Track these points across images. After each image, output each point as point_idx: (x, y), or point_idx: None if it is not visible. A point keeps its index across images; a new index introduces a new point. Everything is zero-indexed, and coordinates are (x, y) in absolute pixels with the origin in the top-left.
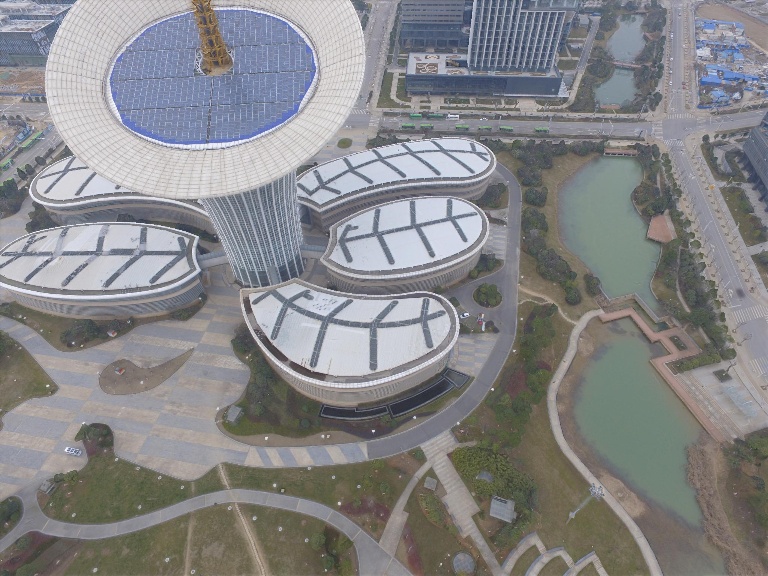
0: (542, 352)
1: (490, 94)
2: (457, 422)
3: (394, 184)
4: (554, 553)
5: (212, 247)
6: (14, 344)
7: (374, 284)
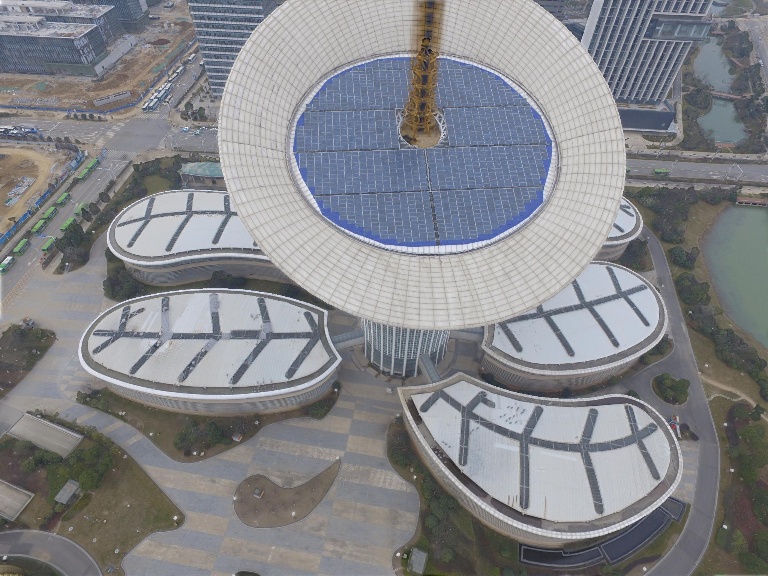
0: (757, 468)
1: None
2: None
3: None
4: None
5: (329, 316)
6: (118, 452)
7: (547, 377)
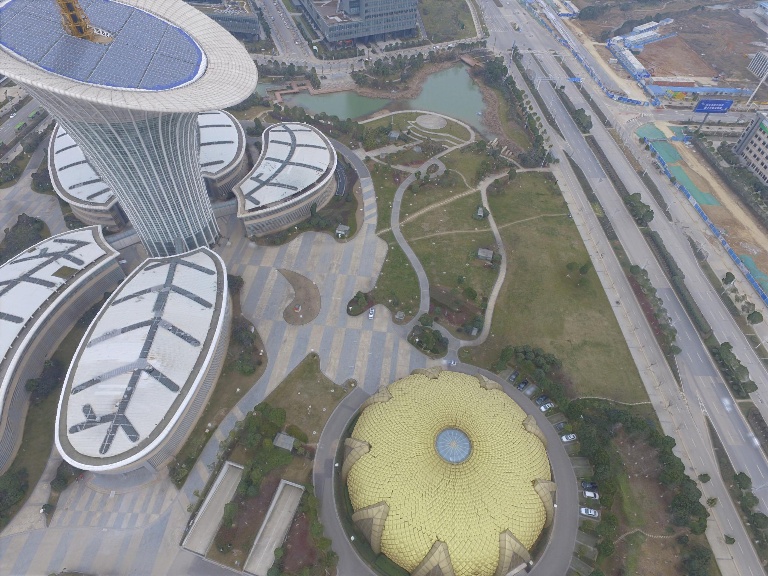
0: None
1: None
2: None
3: None
4: None
5: None
6: None
7: None
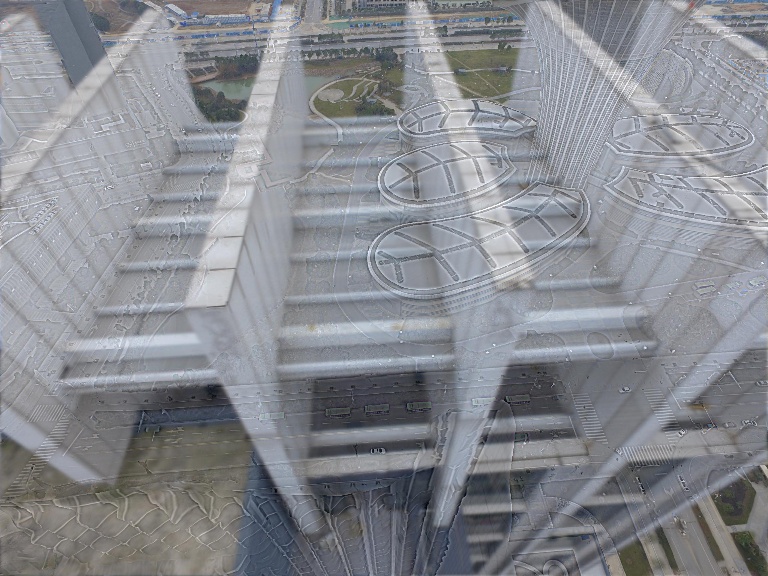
0: None
1: None
2: None
3: None
4: None
5: None
6: None
7: None
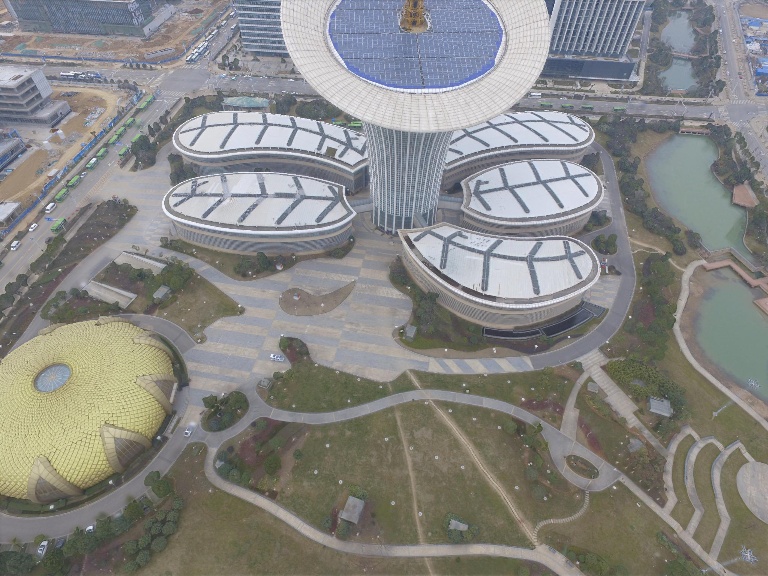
0: (662, 291)
1: (566, 76)
2: (606, 341)
3: (508, 148)
4: (707, 440)
5: None
6: (193, 273)
7: (509, 231)
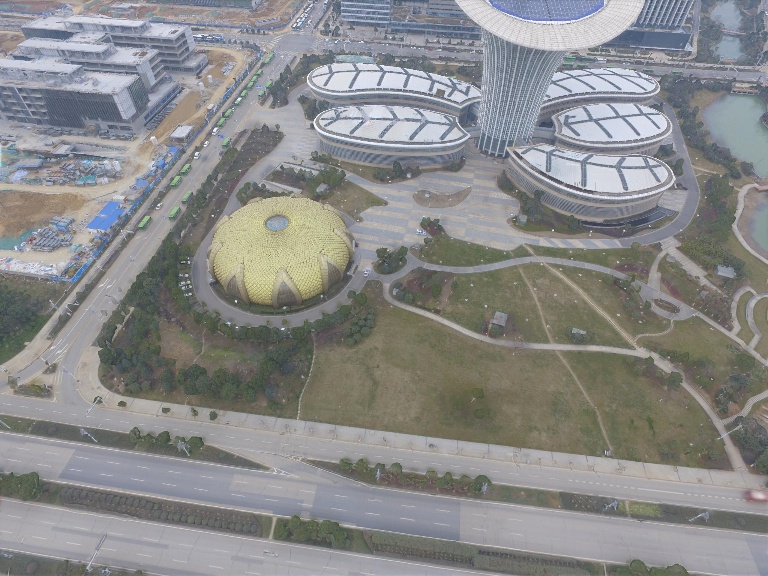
0: None
1: (627, 46)
2: None
3: (587, 94)
4: (763, 295)
5: None
6: None
7: None
